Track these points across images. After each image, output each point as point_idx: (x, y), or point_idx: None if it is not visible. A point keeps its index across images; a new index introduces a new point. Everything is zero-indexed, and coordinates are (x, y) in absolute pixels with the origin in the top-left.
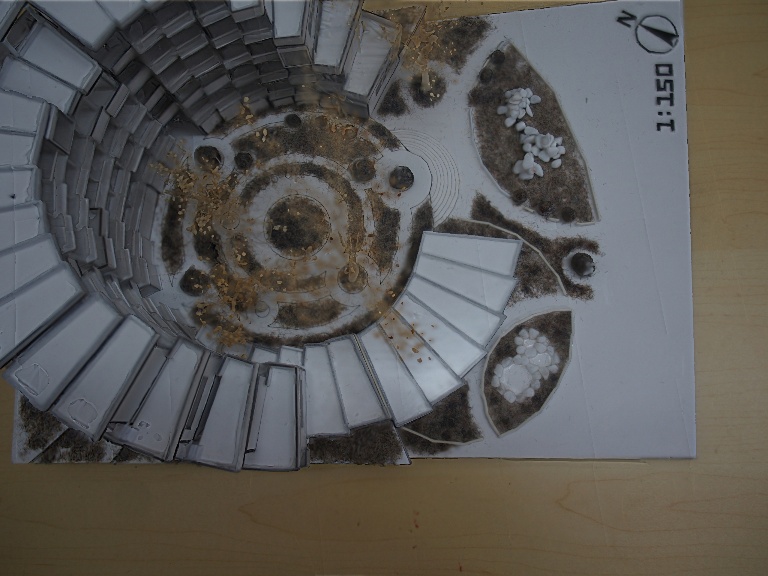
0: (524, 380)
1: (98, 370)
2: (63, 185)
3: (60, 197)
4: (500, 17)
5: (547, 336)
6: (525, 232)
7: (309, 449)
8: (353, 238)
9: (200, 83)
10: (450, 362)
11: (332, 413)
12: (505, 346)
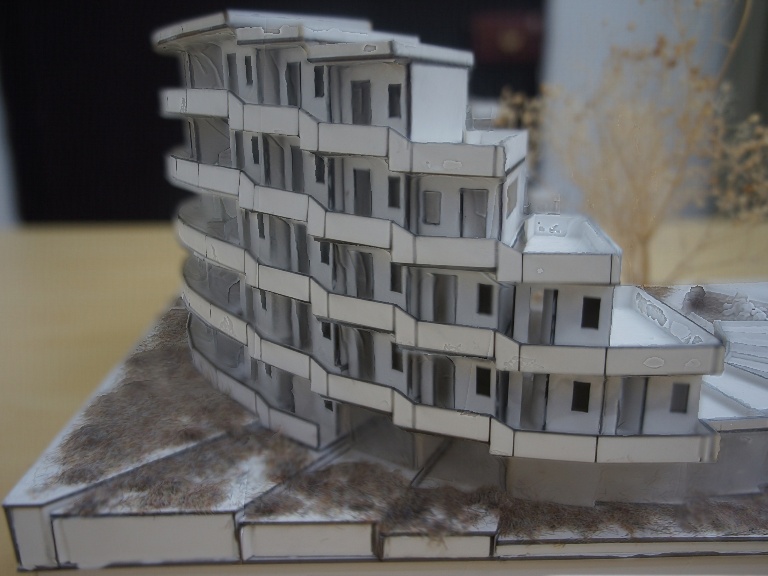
0: None
1: None
2: None
3: None
4: (679, 286)
5: None
6: None
7: None
8: None
9: None
10: None
11: (711, 409)
12: None
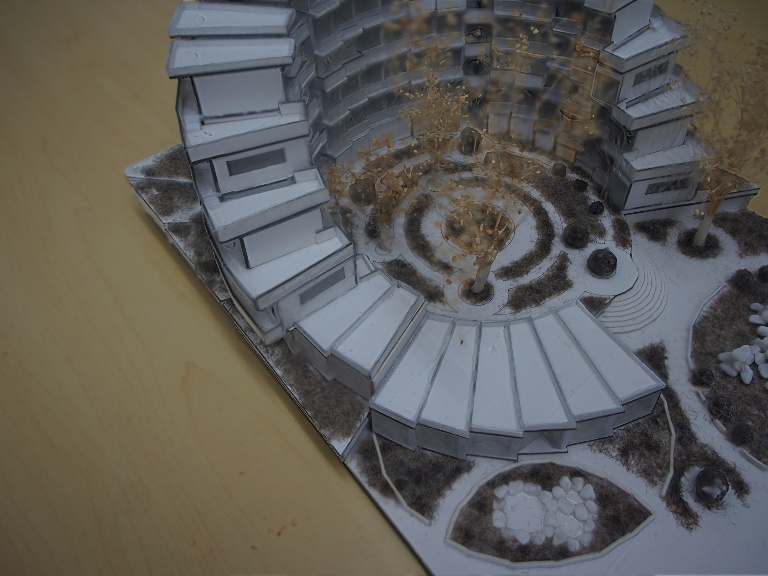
0: (531, 523)
1: (231, 50)
2: None
3: None
4: None
5: (600, 511)
6: (677, 409)
7: (284, 334)
8: (511, 268)
9: None
10: (478, 409)
11: (335, 330)
12: (547, 473)
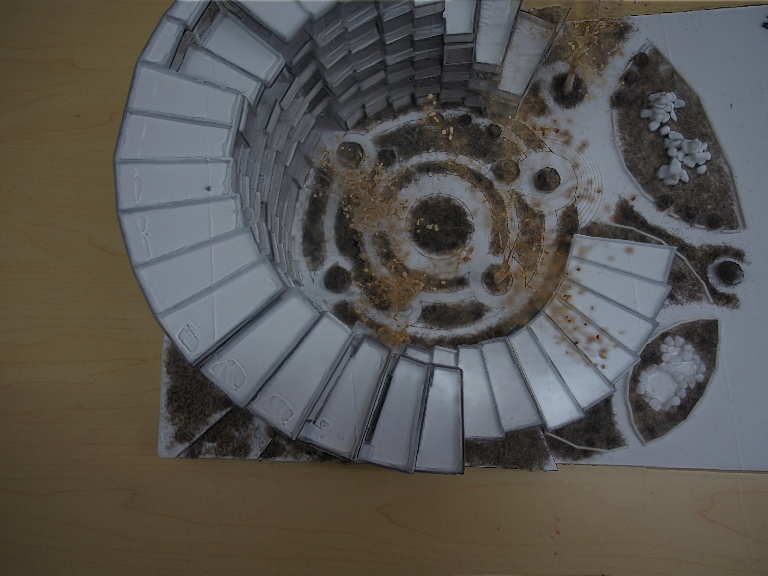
0: (669, 388)
1: (293, 367)
2: (246, 178)
3: (243, 190)
4: (642, 19)
5: (693, 344)
6: (670, 238)
7: None
8: (497, 239)
9: (354, 78)
10: None
11: (486, 416)
12: (650, 353)
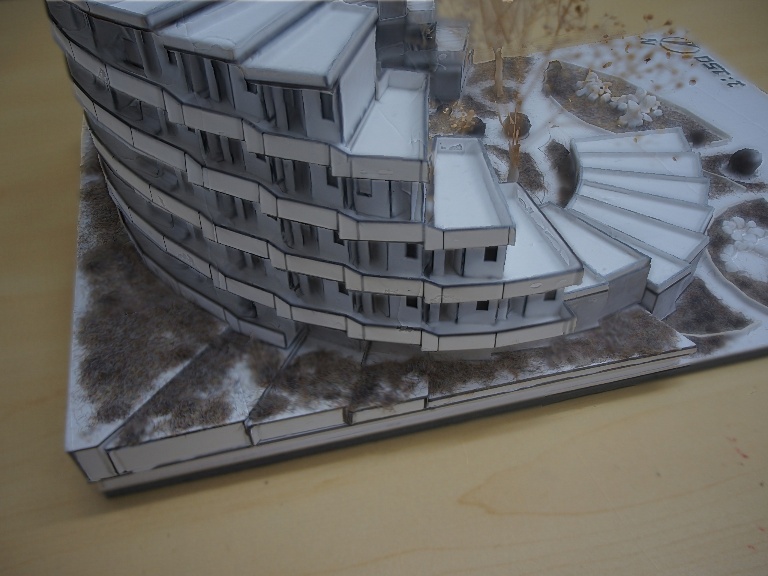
0: (762, 264)
1: (303, 45)
2: None
3: None
4: (539, 54)
5: None
6: None
7: None
8: None
9: None
10: None
11: None
12: (716, 237)
